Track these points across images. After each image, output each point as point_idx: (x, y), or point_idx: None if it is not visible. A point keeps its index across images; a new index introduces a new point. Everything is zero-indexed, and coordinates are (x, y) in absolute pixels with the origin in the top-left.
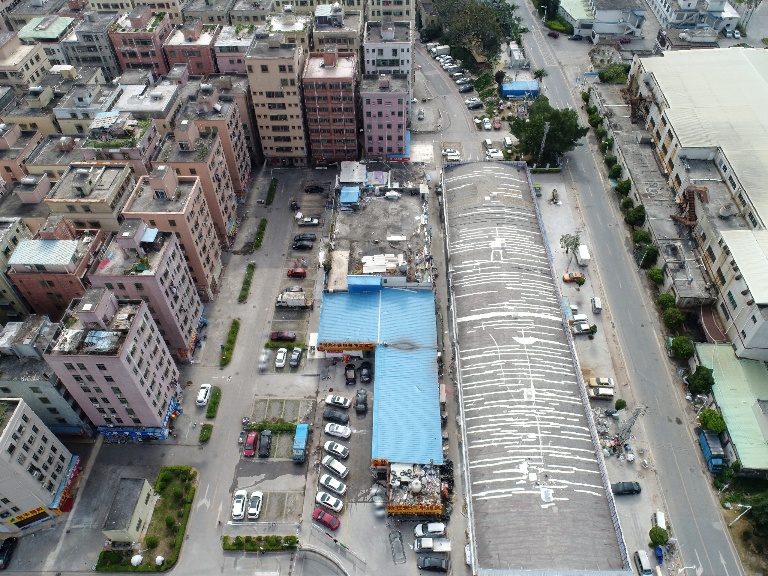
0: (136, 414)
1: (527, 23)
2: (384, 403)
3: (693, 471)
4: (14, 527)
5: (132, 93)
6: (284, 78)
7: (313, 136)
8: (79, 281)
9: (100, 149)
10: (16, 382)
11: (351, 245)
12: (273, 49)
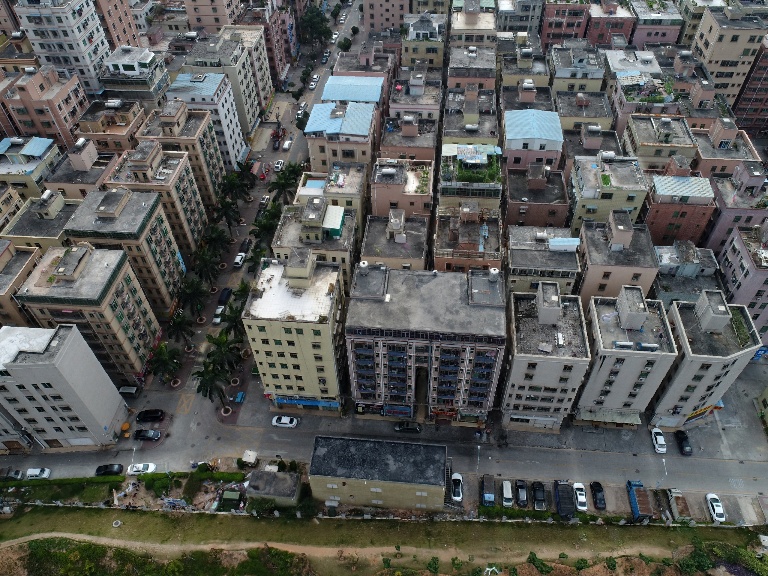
0: (766, 332)
1: None
2: None
3: None
4: (683, 421)
5: (617, 57)
6: (748, 48)
7: (742, 105)
8: (711, 213)
9: (646, 103)
10: (694, 295)
11: None
12: (735, 21)
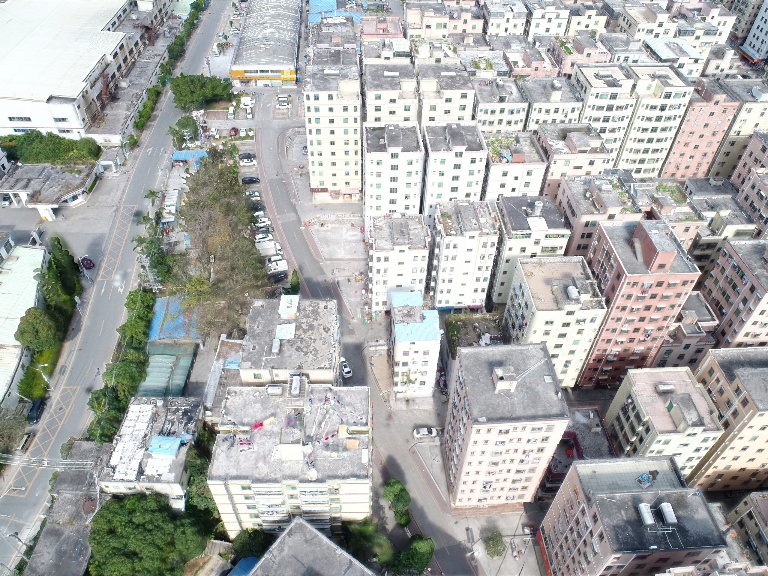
0: None
1: (108, 300)
2: (332, 0)
3: (214, 5)
4: None
5: (518, 7)
6: None
7: None
8: None
9: None
10: None
11: (353, 26)
12: None
